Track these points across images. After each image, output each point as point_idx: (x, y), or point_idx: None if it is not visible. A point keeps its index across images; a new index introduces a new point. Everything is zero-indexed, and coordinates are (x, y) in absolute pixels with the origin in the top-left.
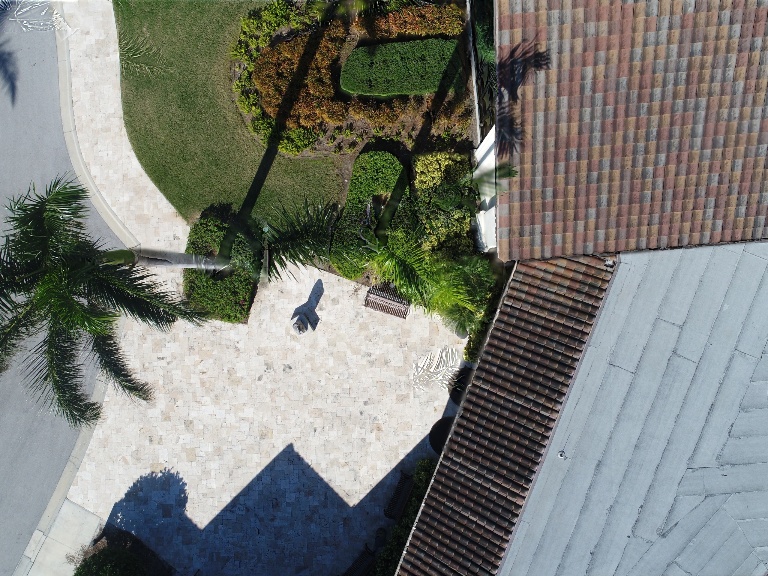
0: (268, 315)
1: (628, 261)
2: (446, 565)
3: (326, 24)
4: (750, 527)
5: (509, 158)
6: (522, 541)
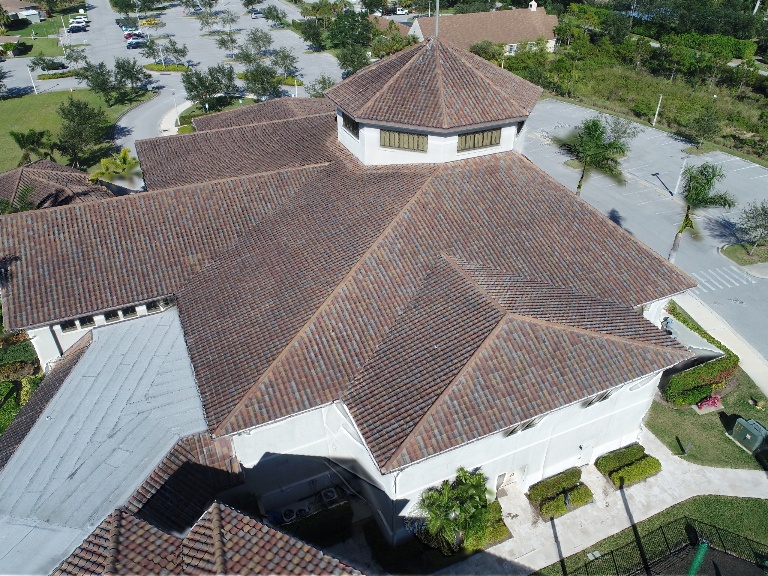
0: None
1: (97, 340)
2: None
3: None
4: None
5: (7, 291)
6: (13, 464)
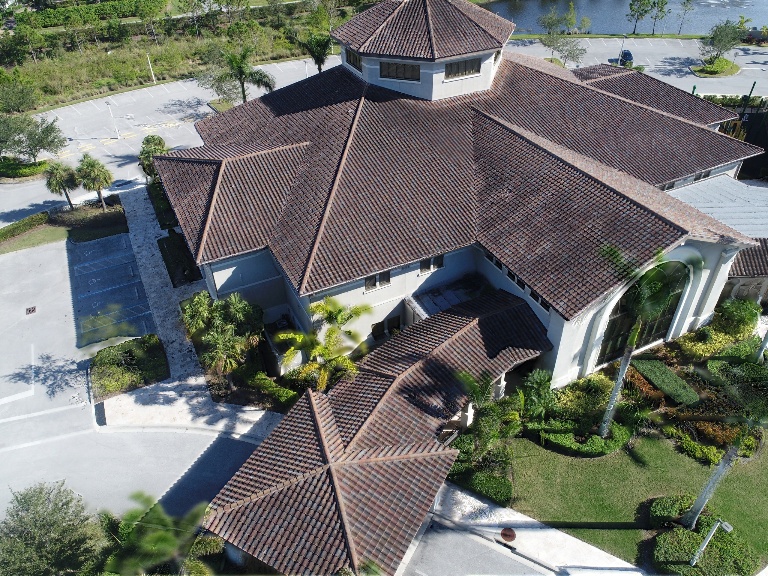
0: None
1: None
2: None
3: (676, 418)
4: None
5: None
6: None
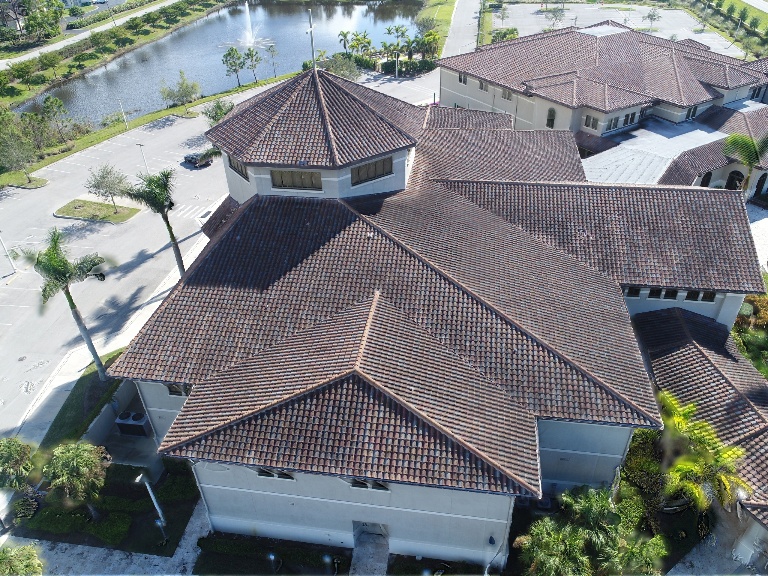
0: (759, 257)
1: None
2: None
3: (767, 324)
4: (592, 164)
5: None
6: None
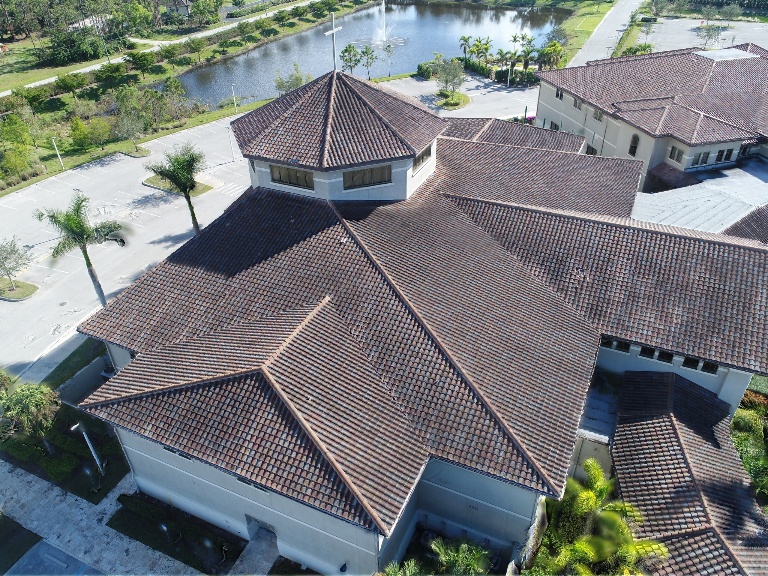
0: None
1: None
2: (766, 223)
3: None
4: (656, 200)
5: None
6: None
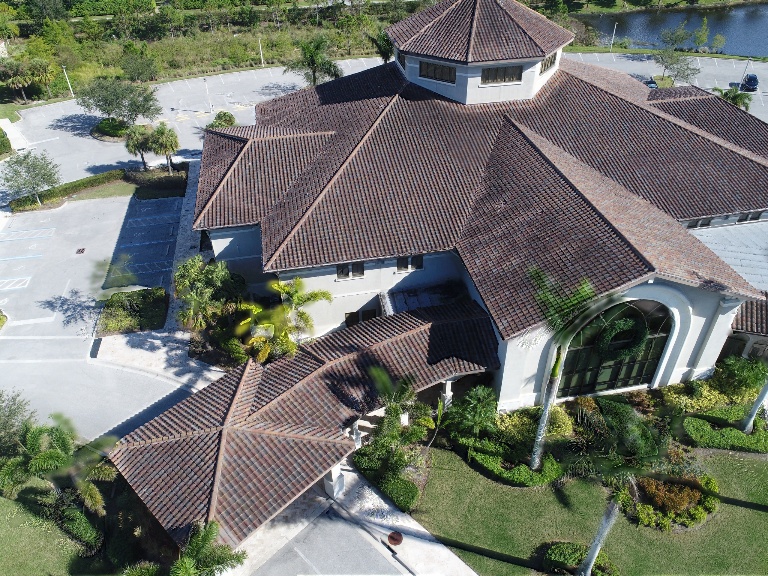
0: None
1: None
2: None
3: (621, 467)
4: None
5: None
6: None
